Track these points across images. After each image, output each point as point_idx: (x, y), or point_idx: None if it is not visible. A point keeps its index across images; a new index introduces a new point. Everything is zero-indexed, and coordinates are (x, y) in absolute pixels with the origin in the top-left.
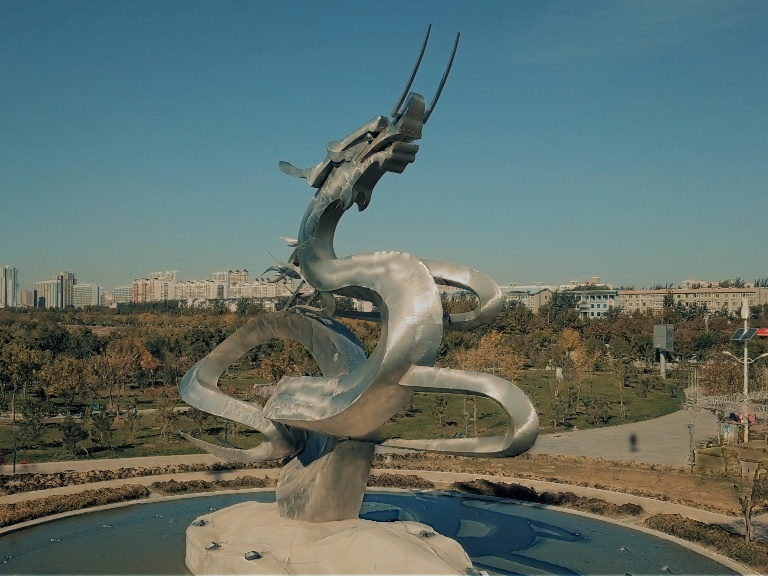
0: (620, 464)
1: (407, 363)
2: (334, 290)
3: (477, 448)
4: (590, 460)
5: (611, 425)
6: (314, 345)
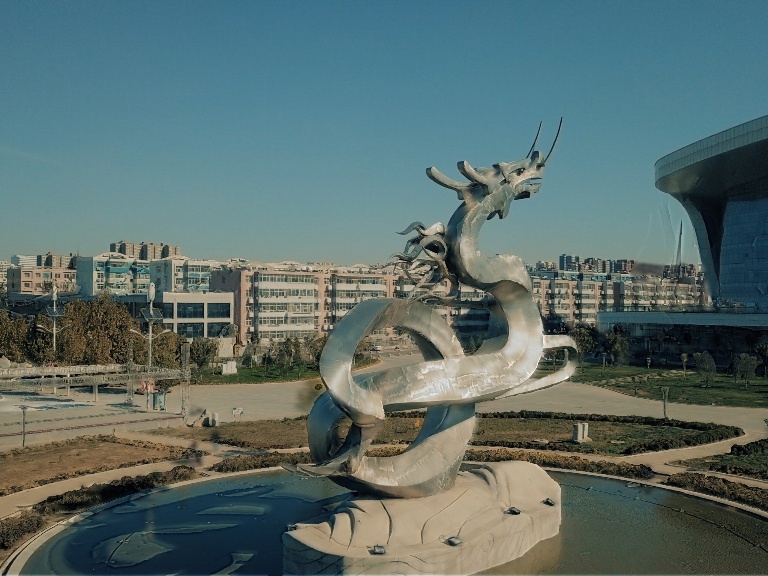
0: None
1: None
2: None
3: None
4: None
5: None
6: None
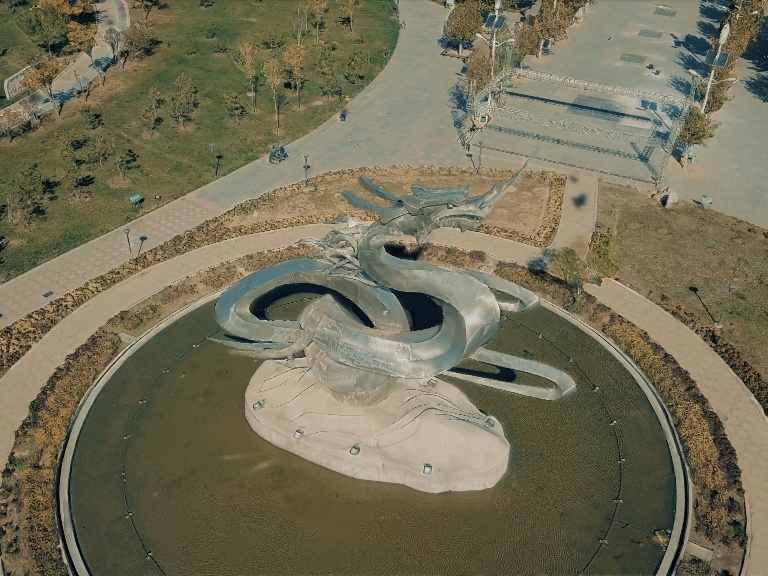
0: (425, 171)
1: (476, 347)
2: None
3: (527, 393)
4: (401, 169)
5: (368, 81)
6: (360, 300)
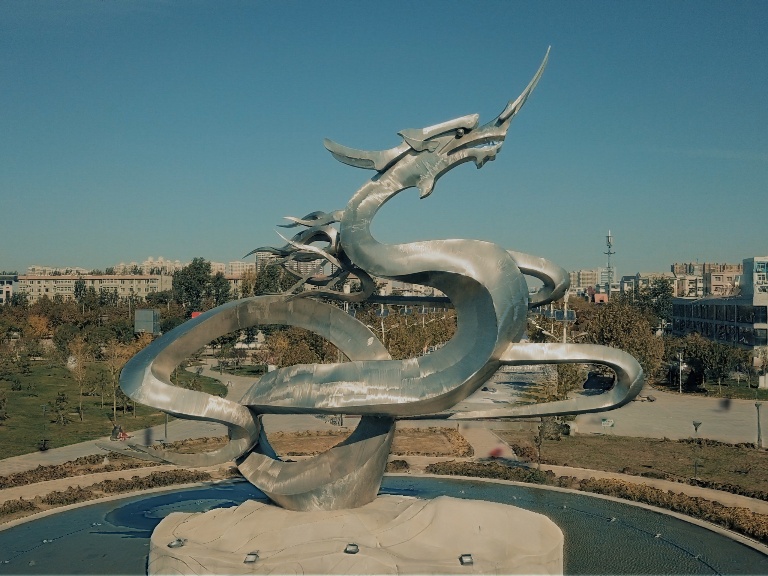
0: (302, 434)
1: (508, 341)
2: (406, 275)
3: (581, 407)
4: (274, 435)
5: None
6: (333, 330)
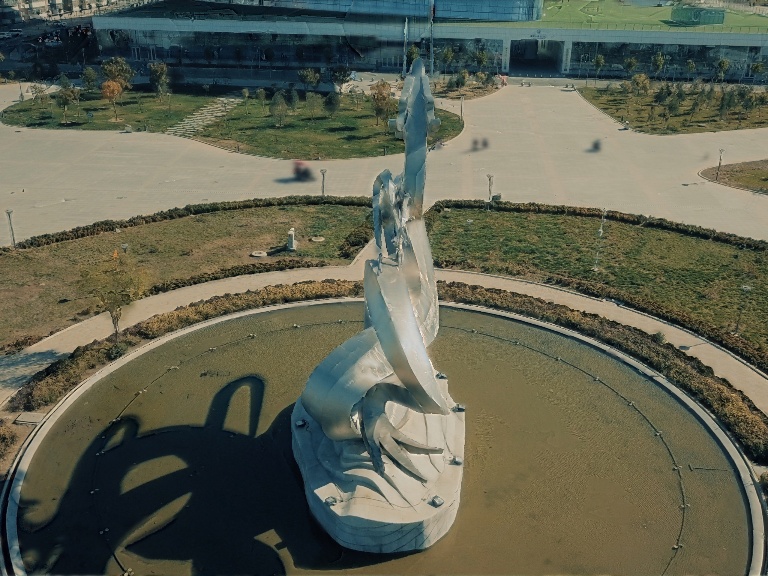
0: None
1: None
2: None
3: None
4: None
5: None
6: None
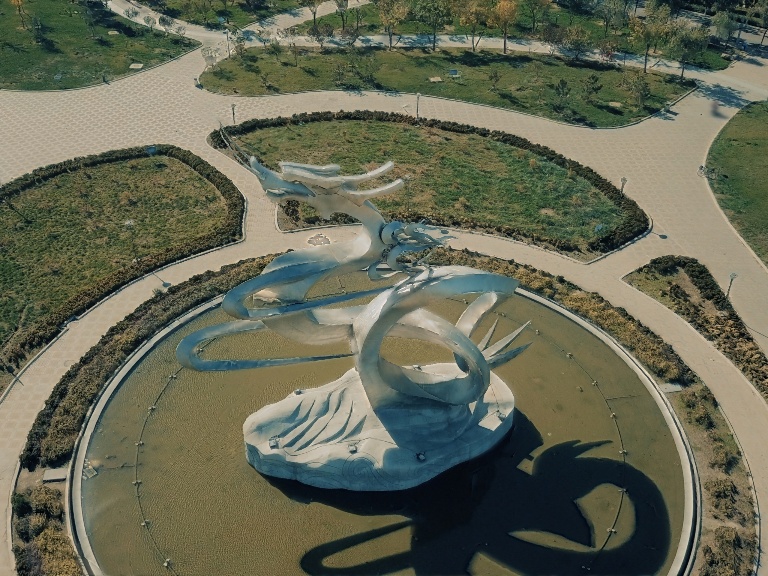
0: None
1: None
2: None
3: None
4: None
5: None
6: None
